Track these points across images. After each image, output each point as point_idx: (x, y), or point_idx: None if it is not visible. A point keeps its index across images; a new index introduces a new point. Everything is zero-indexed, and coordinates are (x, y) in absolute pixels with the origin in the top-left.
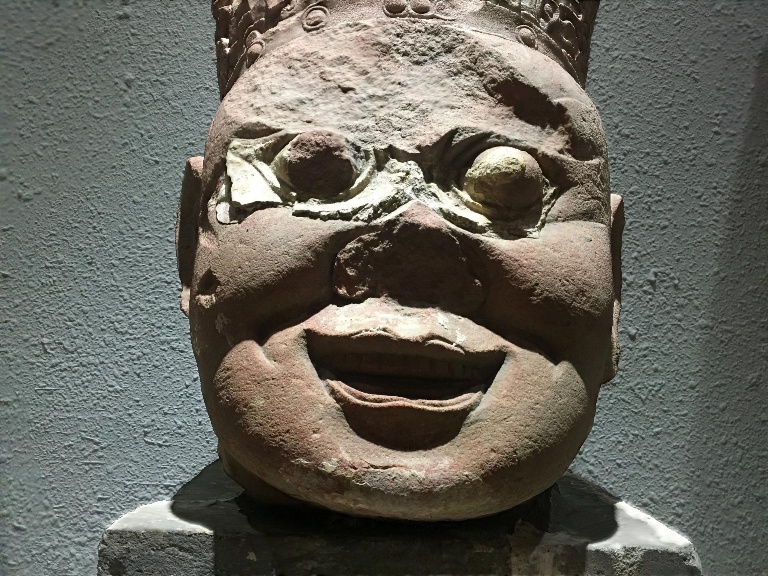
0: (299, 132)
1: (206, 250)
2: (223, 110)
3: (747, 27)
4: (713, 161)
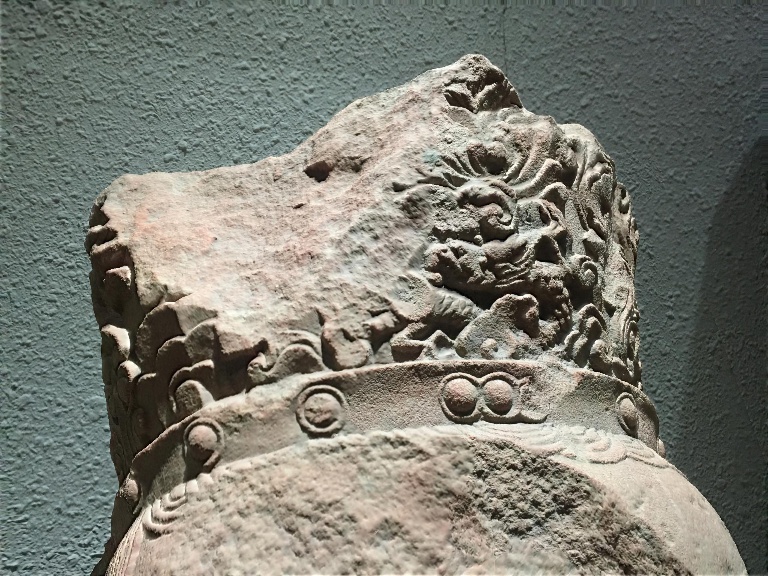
0: None
1: None
2: None
3: (697, 196)
4: (667, 350)
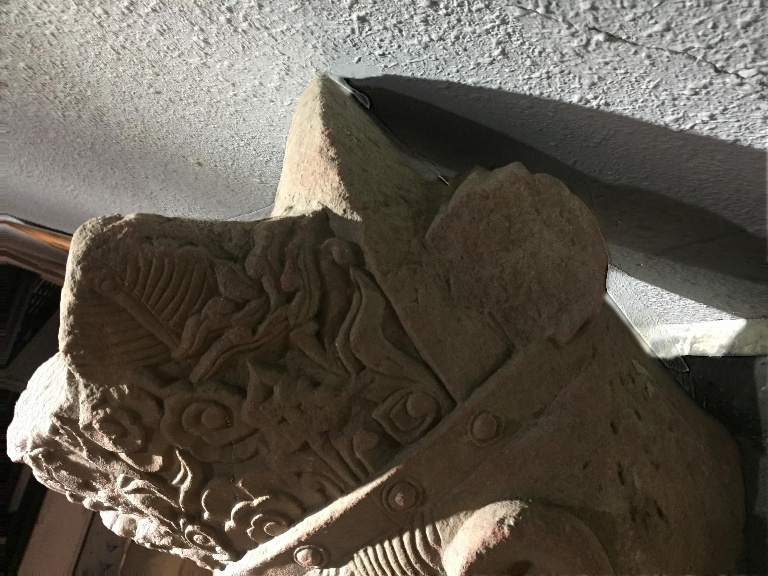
0: None
1: None
2: None
3: None
4: None
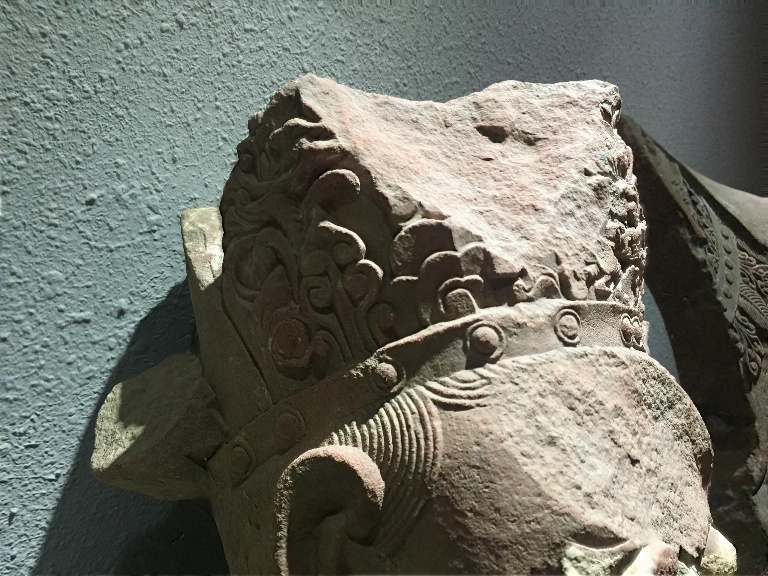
0: (642, 544)
1: None
2: (527, 475)
3: None
4: None
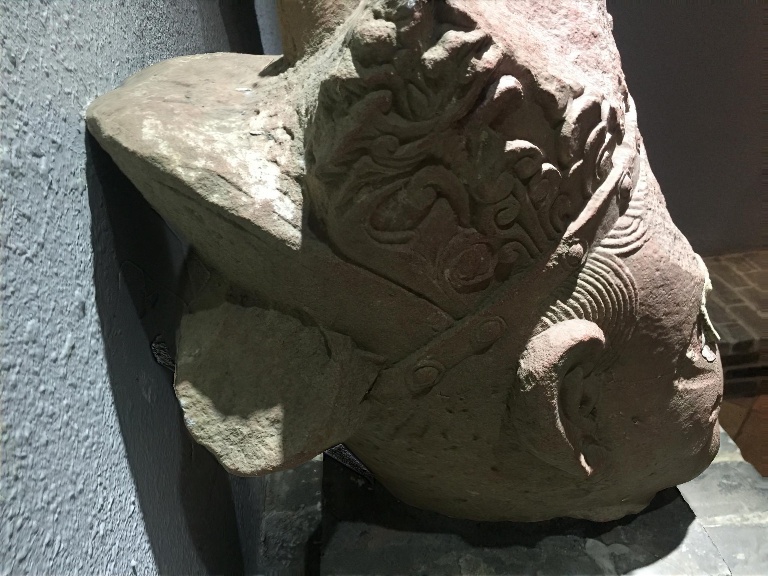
0: None
1: (711, 387)
2: (686, 272)
3: None
4: None
